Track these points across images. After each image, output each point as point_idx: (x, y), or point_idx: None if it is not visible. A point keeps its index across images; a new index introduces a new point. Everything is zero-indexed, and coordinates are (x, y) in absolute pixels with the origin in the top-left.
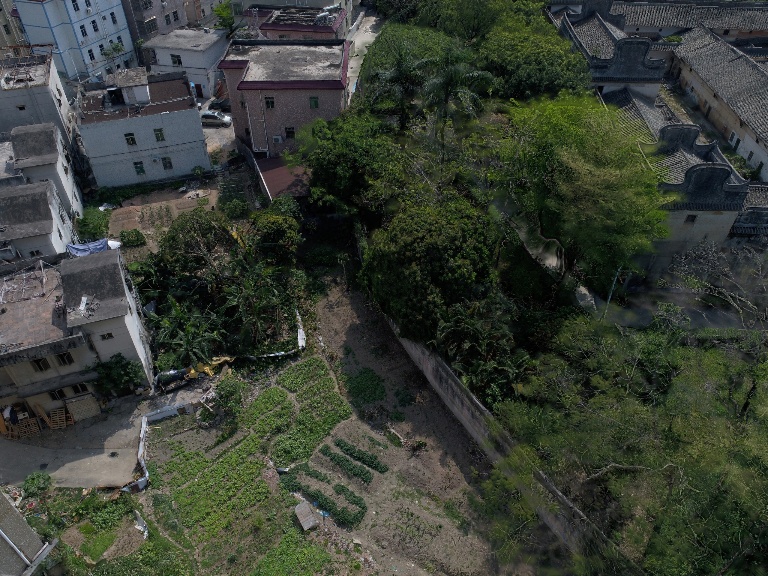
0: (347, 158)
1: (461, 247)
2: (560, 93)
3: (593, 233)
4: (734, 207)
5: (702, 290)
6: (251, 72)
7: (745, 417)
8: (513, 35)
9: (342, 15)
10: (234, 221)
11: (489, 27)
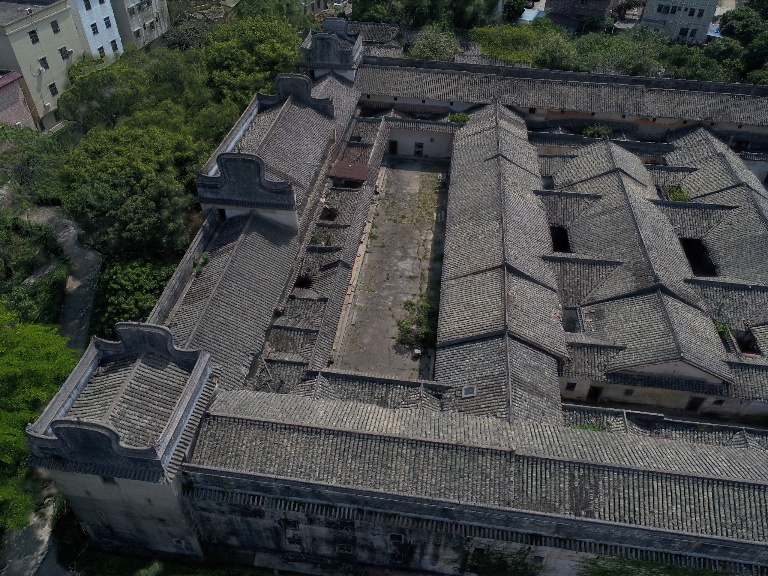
0: None
1: None
2: (110, 230)
3: None
4: (149, 477)
5: None
6: None
7: None
8: (130, 131)
9: (4, 80)
10: None
11: None
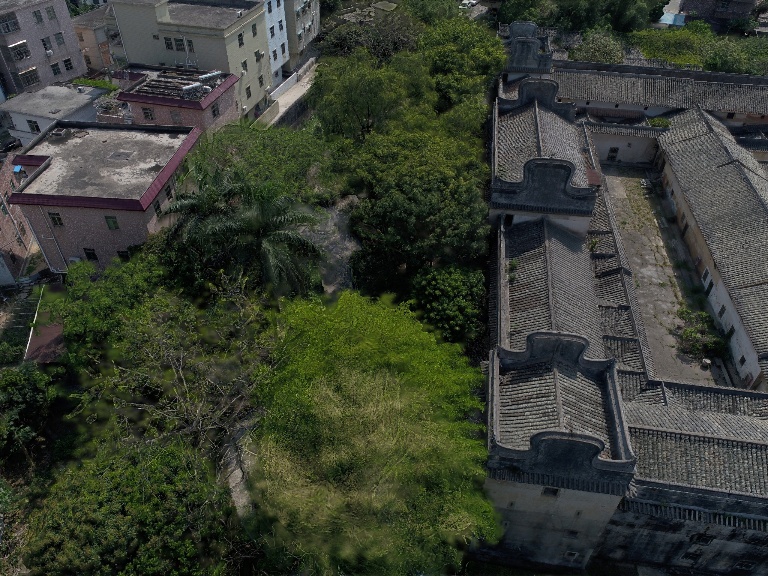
0: (97, 327)
1: (135, 552)
2: (432, 235)
3: (347, 549)
4: (613, 490)
5: None
6: (46, 174)
7: None
8: (404, 135)
9: (227, 83)
10: (4, 368)
11: (380, 120)
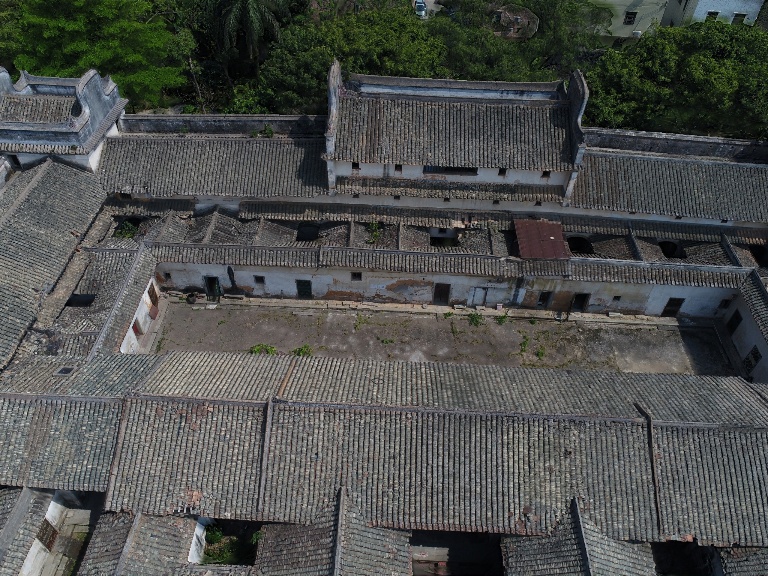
0: None
1: None
2: None
3: None
4: None
5: None
6: None
7: None
8: None
9: None
10: None
11: None
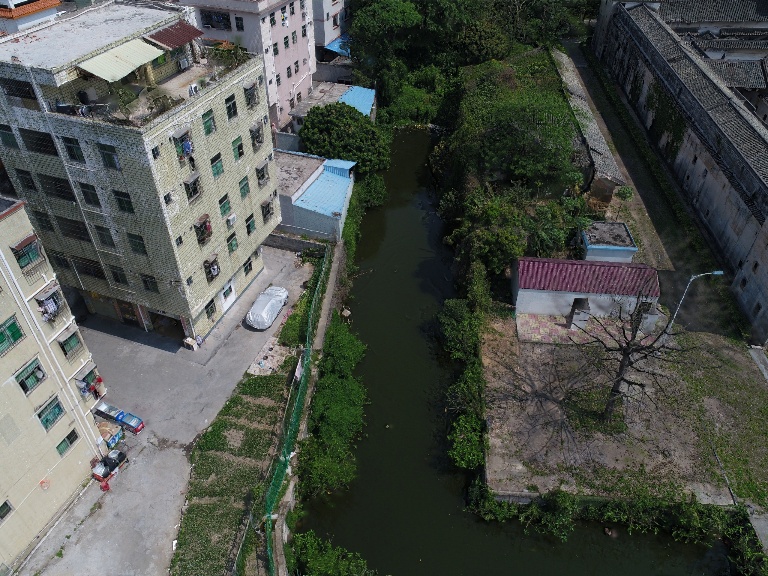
0: None
1: None
2: None
3: None
4: None
5: None
6: None
7: (513, 53)
8: None
9: None
10: None
11: None
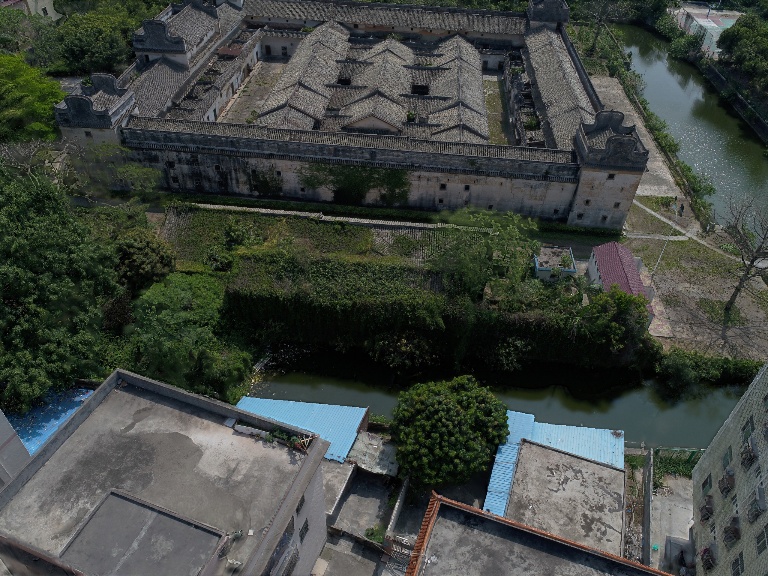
0: None
1: None
2: (86, 56)
3: None
4: (106, 126)
5: (7, 164)
6: None
7: None
8: None
9: None
10: None
11: None
